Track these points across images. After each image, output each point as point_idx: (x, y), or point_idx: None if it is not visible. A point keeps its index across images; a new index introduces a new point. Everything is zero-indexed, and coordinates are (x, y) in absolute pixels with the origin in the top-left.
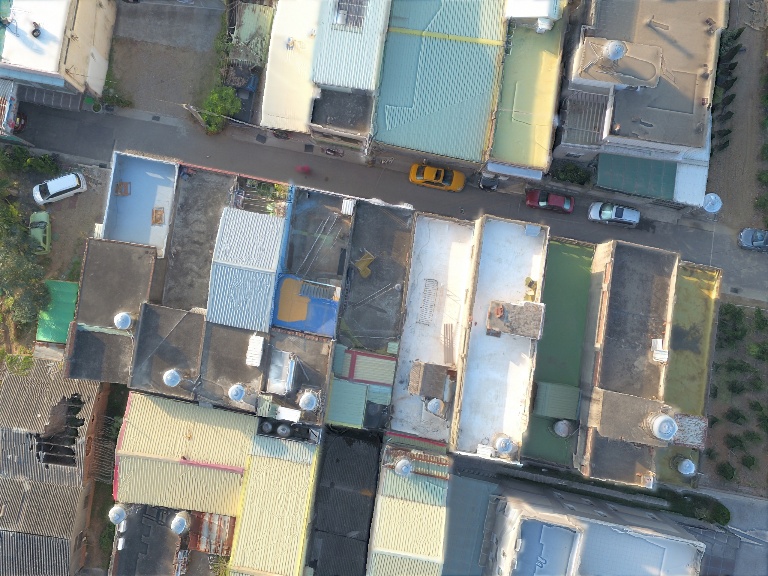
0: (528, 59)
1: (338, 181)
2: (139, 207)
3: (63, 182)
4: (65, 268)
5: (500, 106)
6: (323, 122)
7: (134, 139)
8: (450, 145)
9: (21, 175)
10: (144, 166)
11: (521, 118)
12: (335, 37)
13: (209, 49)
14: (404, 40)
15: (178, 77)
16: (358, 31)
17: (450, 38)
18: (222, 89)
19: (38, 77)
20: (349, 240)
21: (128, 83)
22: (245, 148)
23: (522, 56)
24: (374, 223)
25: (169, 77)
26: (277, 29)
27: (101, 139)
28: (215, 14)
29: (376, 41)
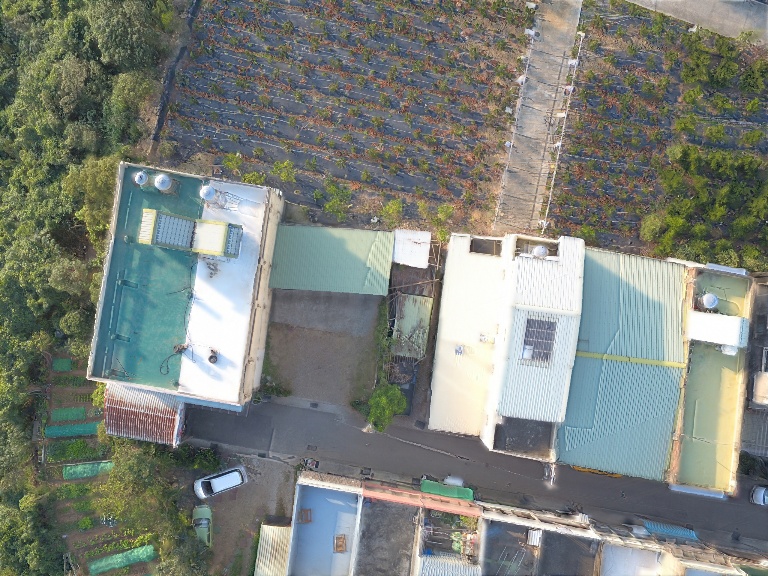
0: (707, 376)
1: (498, 467)
2: (320, 534)
3: (227, 481)
4: (227, 561)
5: (683, 430)
6: (502, 443)
7: (292, 428)
8: (630, 464)
9: (180, 467)
10: (324, 492)
11: (701, 437)
12: (521, 372)
13: (365, 334)
14: (585, 363)
15: (335, 363)
16: (544, 366)
17: (631, 361)
18: (387, 388)
19: (215, 403)
20: (536, 571)
21: (285, 370)
22: (404, 435)
23: (701, 373)
24: (557, 548)
25: (326, 363)
26: (445, 334)
27: (259, 428)
28: (370, 298)
29: (562, 375)
